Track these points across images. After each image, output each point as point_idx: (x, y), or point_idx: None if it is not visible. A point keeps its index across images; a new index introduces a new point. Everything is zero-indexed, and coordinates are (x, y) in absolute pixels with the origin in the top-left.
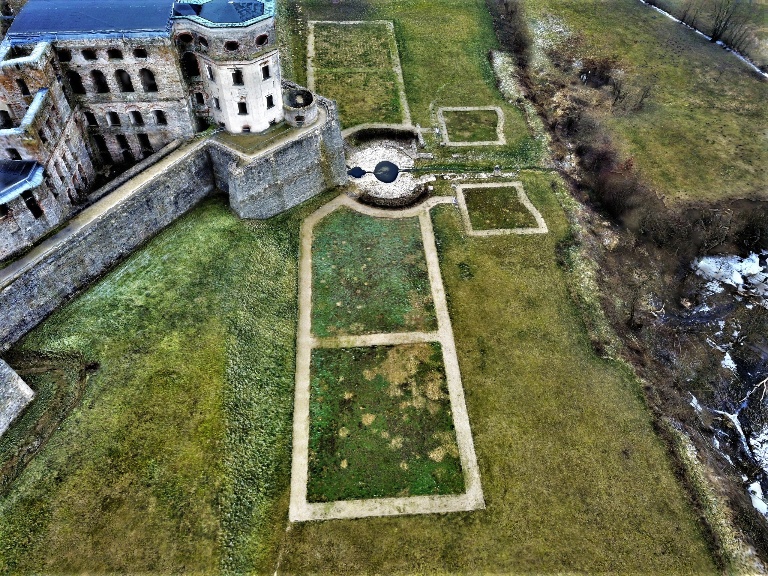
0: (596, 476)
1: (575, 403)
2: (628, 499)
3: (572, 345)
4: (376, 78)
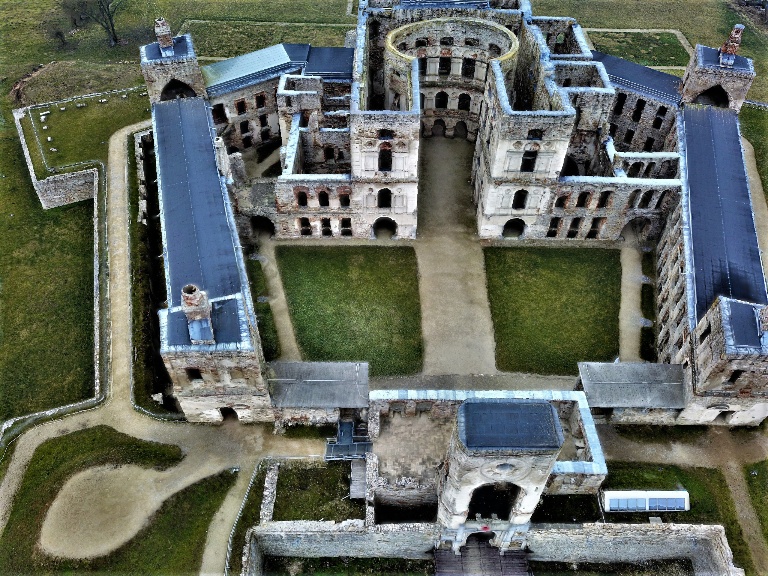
0: (652, 7)
1: (614, 6)
2: (660, 3)
3: (579, 2)
4: (295, 32)
